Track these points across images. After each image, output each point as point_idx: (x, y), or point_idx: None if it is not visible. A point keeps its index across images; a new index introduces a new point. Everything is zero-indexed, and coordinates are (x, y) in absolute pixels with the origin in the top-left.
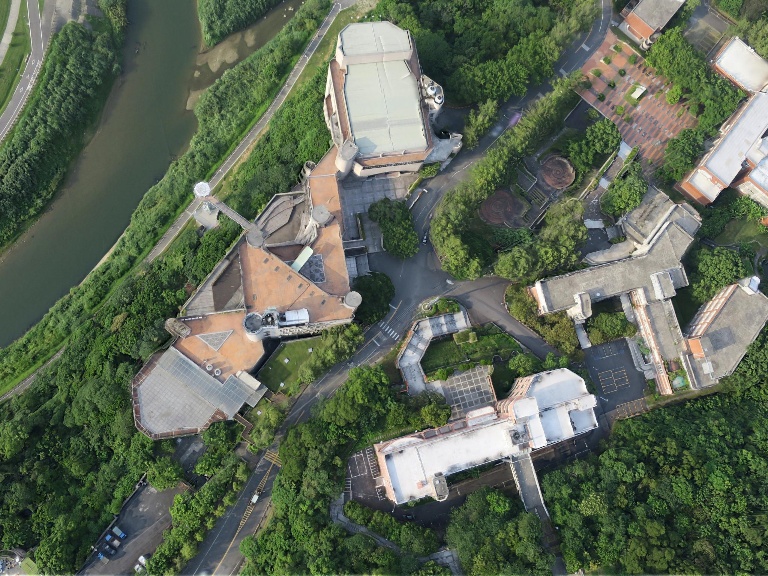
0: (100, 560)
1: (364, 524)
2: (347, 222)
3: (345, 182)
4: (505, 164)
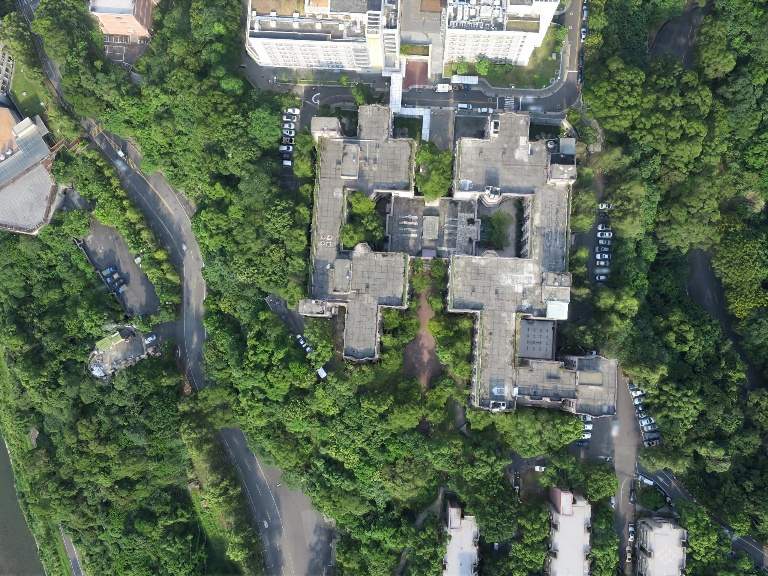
0: (124, 293)
1: None
2: None
3: None
4: None
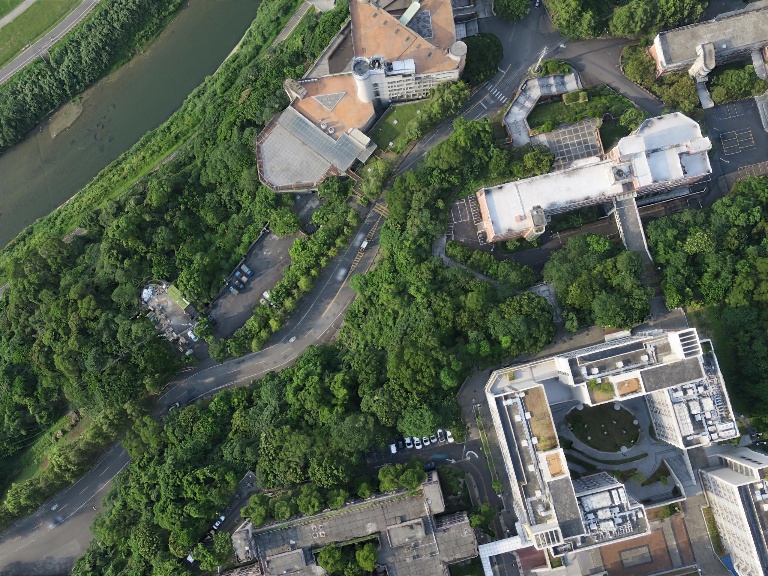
0: (231, 293)
1: (464, 261)
2: None
3: None
4: None
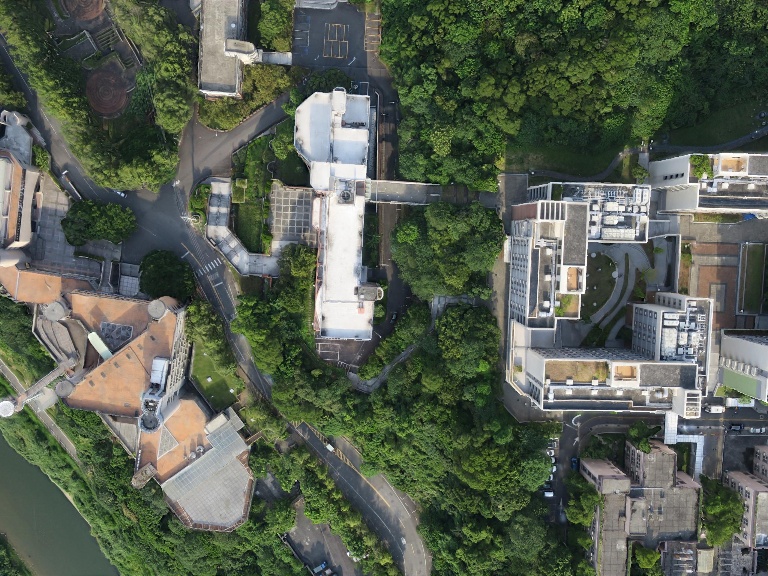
0: None
1: None
2: (82, 268)
3: (34, 257)
4: (49, 76)
